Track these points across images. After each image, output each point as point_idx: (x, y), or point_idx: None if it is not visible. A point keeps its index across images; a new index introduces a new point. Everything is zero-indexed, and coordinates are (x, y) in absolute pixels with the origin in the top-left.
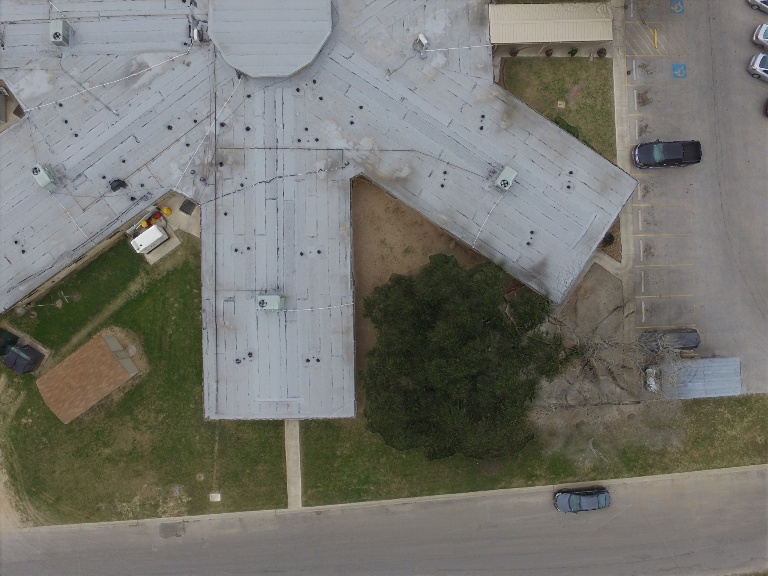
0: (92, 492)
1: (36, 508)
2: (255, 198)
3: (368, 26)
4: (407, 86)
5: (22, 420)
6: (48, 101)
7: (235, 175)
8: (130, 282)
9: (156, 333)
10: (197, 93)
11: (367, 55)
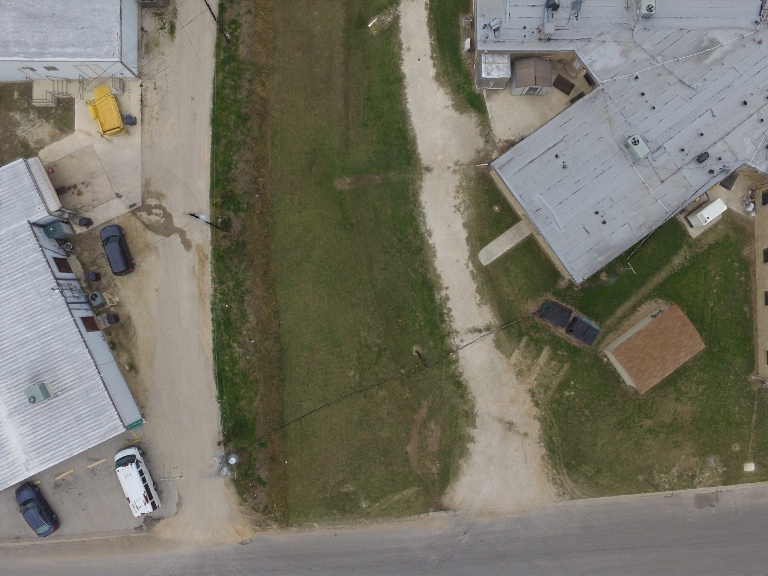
0: (632, 464)
1: (574, 481)
2: None
3: None
4: None
5: (565, 393)
6: (622, 73)
7: None
8: (674, 255)
9: (699, 305)
10: None
11: None
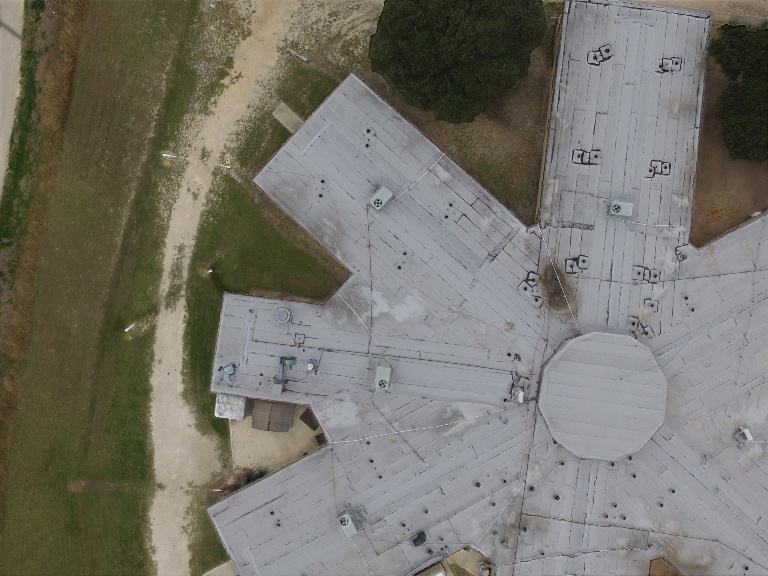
0: None
1: None
2: (554, 568)
3: (691, 407)
4: (721, 474)
5: None
6: (354, 435)
7: (537, 541)
8: None
9: None
10: (511, 453)
11: (686, 437)
